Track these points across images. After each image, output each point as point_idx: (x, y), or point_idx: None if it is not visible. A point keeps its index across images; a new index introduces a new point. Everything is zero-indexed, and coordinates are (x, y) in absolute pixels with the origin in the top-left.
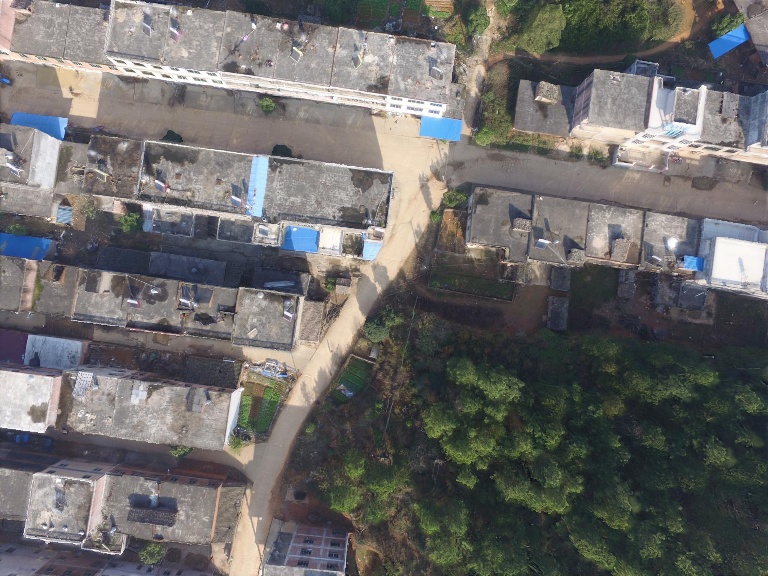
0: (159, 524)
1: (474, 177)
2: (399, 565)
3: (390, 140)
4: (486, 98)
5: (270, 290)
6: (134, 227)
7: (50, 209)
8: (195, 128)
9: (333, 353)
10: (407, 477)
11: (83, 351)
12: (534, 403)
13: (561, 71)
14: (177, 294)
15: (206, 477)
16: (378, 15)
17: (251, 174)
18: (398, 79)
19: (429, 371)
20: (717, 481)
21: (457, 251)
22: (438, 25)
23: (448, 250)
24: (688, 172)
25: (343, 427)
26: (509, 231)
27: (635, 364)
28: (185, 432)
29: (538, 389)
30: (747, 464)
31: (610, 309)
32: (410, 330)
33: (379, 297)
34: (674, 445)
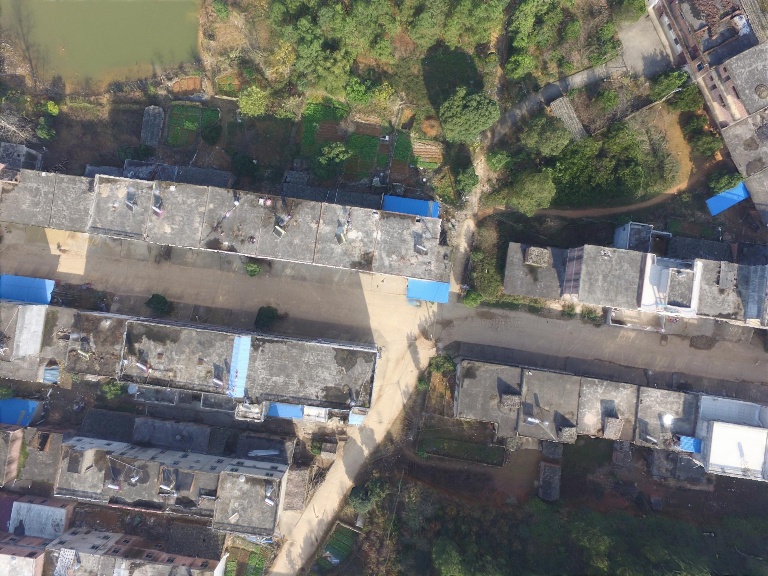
0: None
1: (463, 336)
2: None
3: (377, 297)
4: (475, 258)
5: (252, 474)
6: (118, 395)
7: (36, 373)
8: (181, 285)
9: (319, 518)
10: None
11: (68, 517)
12: None
13: (552, 232)
14: (158, 476)
15: None
16: (365, 166)
17: (233, 353)
18: (382, 255)
19: (416, 549)
20: None
21: (446, 414)
22: (426, 177)
23: (437, 412)
24: (686, 331)
25: None
26: (498, 406)
27: (628, 559)
28: None
29: None
30: None
31: (605, 475)
32: (396, 505)
33: (366, 461)
34: None
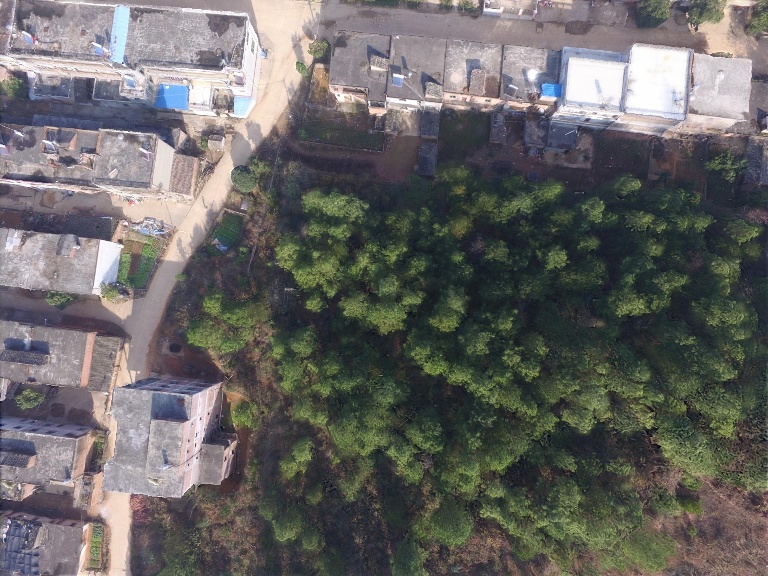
0: (28, 363)
1: None
2: (264, 407)
3: (264, 4)
4: None
5: (130, 131)
6: (17, 91)
7: None
8: None
9: (208, 209)
10: (268, 316)
11: None
12: (379, 224)
13: None
14: None
15: (84, 329)
16: None
17: (113, 24)
18: None
19: (292, 214)
20: (560, 289)
21: (328, 106)
22: None
23: None
24: (561, 17)
25: (214, 277)
26: (367, 72)
27: (485, 186)
28: (56, 277)
29: (385, 213)
30: (587, 266)
31: (483, 157)
32: None
33: (253, 154)
34: (518, 257)
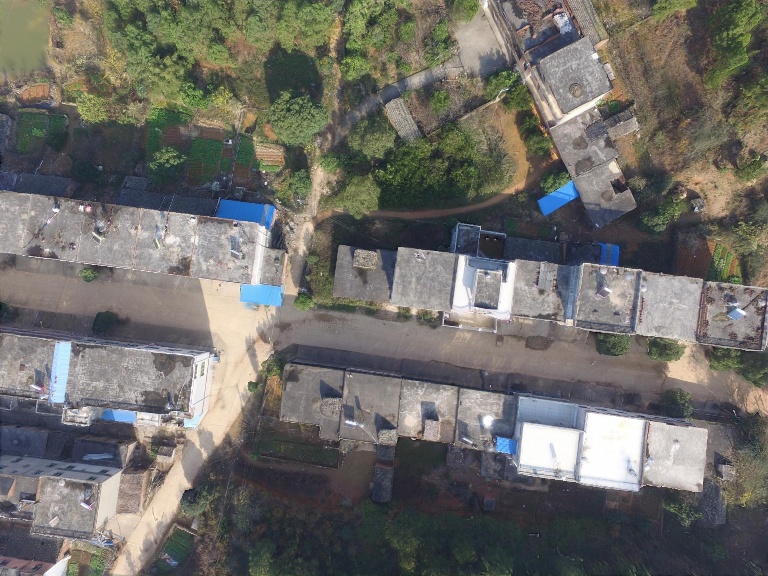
0: None
1: (301, 338)
2: None
3: (217, 301)
4: (308, 261)
5: (71, 478)
6: None
7: None
8: (26, 291)
9: (158, 521)
10: None
11: None
12: None
13: (382, 234)
14: None
15: None
16: (209, 170)
17: (54, 359)
18: (200, 260)
19: (242, 551)
20: None
21: None
22: (268, 180)
23: (274, 415)
24: (521, 331)
25: None
26: (320, 408)
27: (436, 561)
28: None
29: None
30: None
31: (440, 476)
32: (224, 507)
33: (204, 463)
34: None
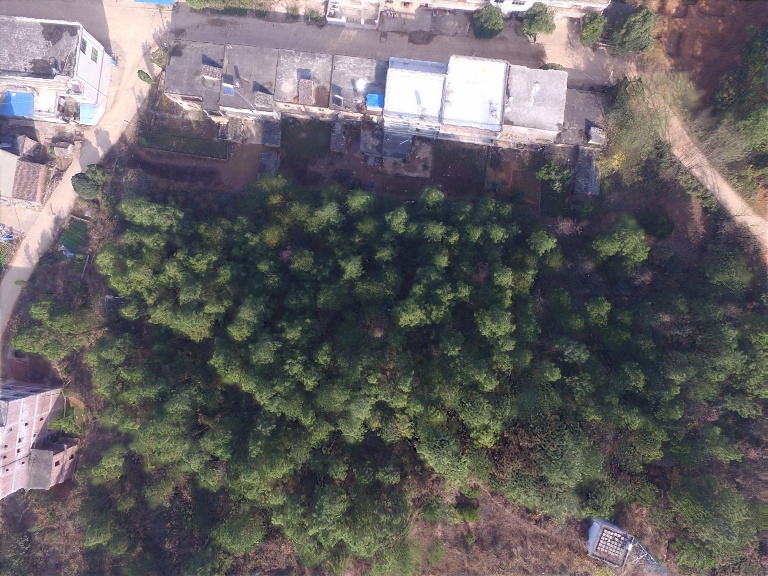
0: None
1: None
2: (96, 413)
3: (116, 12)
4: None
5: None
6: None
7: None
8: None
9: (56, 216)
10: (100, 323)
11: None
12: (194, 233)
13: None
14: None
15: None
16: None
17: None
18: None
19: None
20: (358, 299)
21: (175, 113)
22: None
23: (168, 113)
24: (404, 27)
25: (57, 283)
26: (202, 81)
27: (301, 195)
28: None
29: None
30: (380, 276)
31: (325, 165)
32: None
33: (101, 161)
34: (321, 266)
